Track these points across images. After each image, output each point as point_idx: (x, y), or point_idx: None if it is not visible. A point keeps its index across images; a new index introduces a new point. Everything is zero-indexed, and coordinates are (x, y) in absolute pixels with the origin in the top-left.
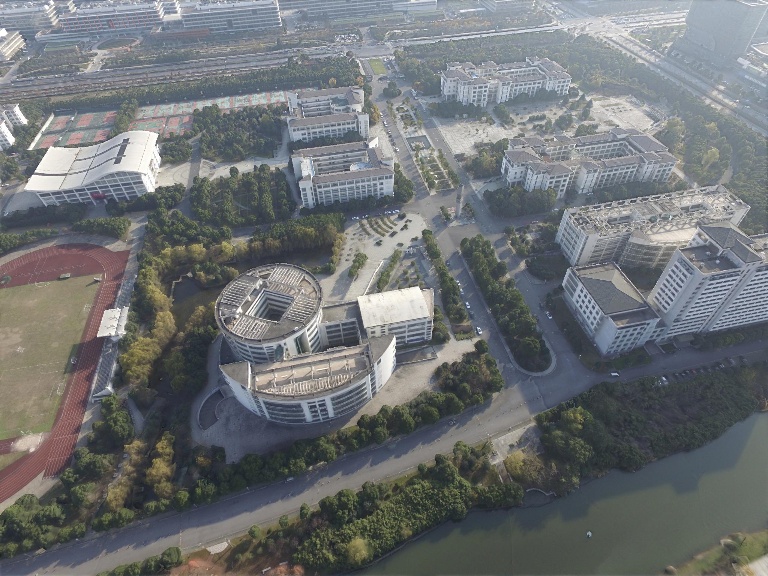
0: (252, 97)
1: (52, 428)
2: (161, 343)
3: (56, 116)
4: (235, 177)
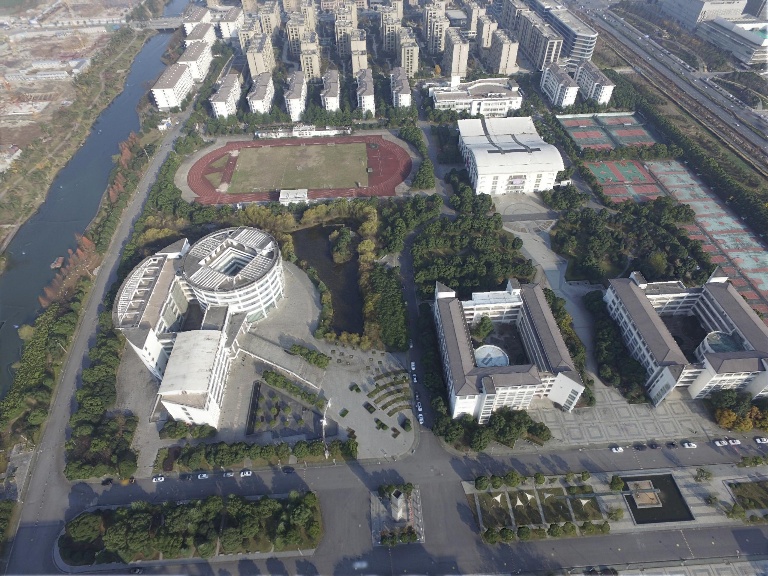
0: (755, 251)
1: (228, 193)
2: (266, 223)
3: (633, 116)
4: (505, 245)
